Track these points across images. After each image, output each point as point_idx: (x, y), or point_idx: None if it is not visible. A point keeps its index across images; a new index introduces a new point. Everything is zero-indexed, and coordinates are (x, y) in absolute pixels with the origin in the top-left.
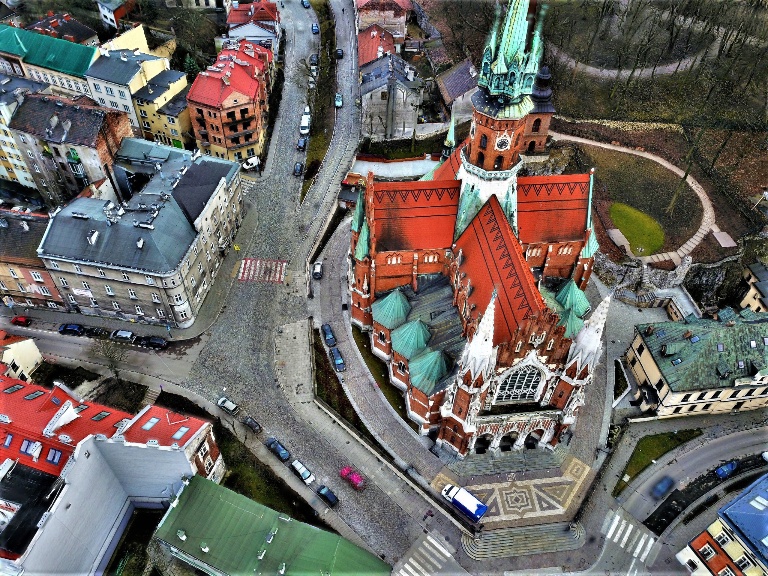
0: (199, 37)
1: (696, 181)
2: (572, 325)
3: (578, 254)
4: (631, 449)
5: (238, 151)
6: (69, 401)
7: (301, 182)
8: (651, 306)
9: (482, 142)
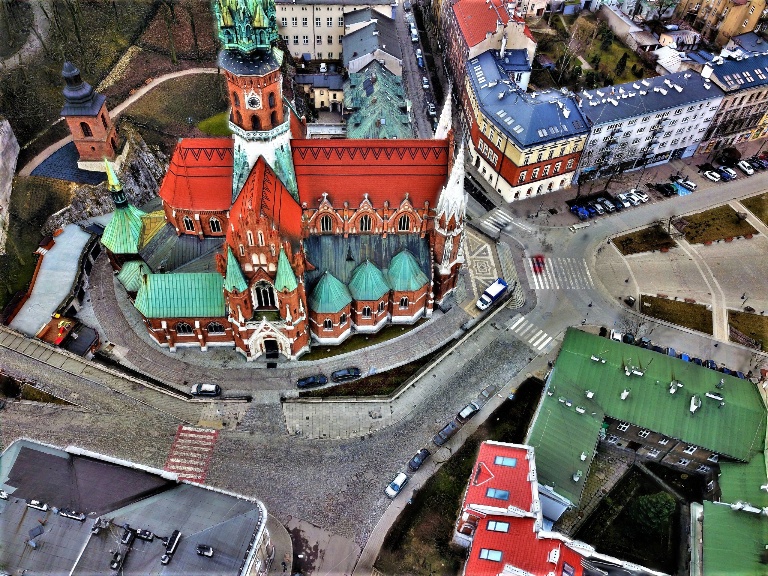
0: None
1: (203, 68)
2: None
3: None
4: None
5: None
6: (505, 567)
7: (20, 402)
8: None
9: (270, 102)
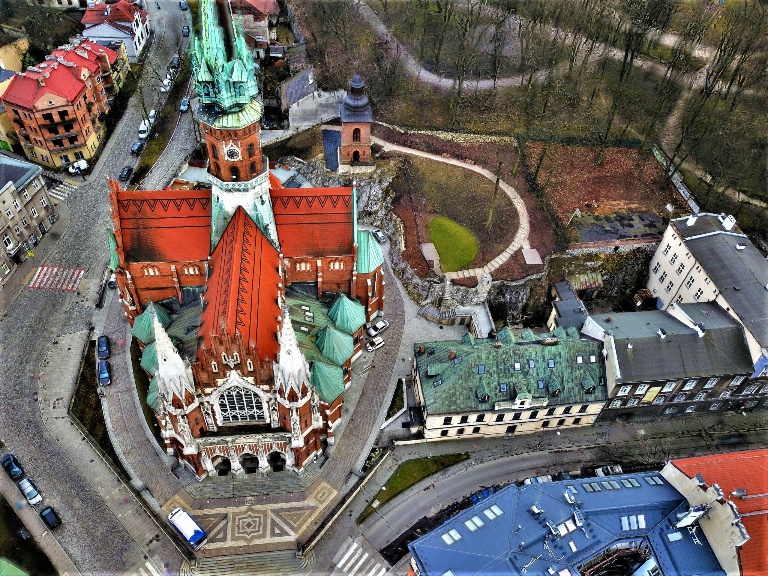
0: (57, 36)
1: (519, 196)
2: (330, 343)
3: (352, 269)
4: (390, 473)
5: (64, 154)
6: None
7: (125, 187)
8: (453, 323)
9: (215, 152)
